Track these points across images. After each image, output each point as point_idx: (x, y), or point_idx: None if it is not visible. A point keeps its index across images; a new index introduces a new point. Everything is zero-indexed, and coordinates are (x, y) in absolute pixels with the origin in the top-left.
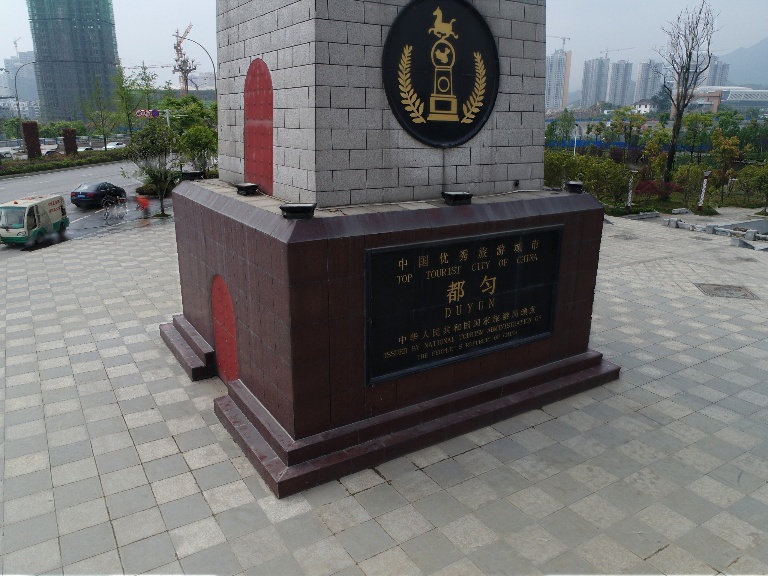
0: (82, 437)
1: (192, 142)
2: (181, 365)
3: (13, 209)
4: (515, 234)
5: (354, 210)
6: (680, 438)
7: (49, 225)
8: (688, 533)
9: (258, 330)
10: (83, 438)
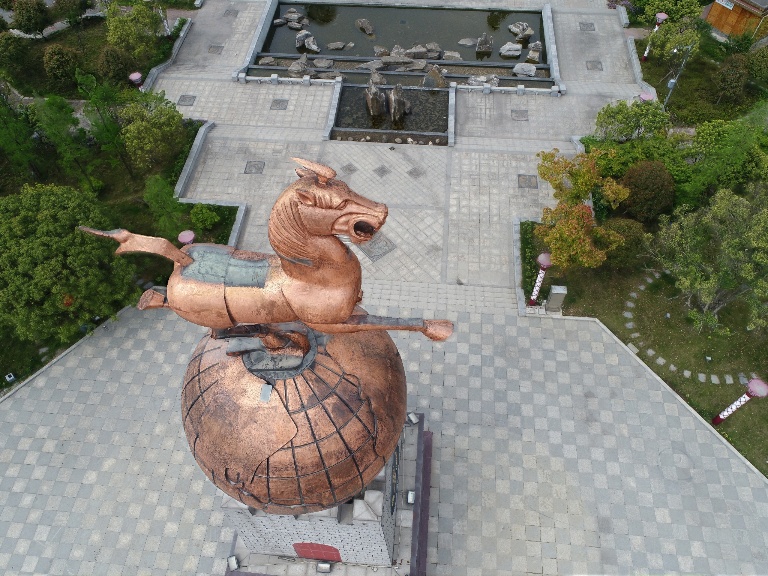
0: None
1: None
2: None
3: None
4: None
5: (403, 553)
6: (477, 463)
7: None
8: (511, 516)
9: None
10: None
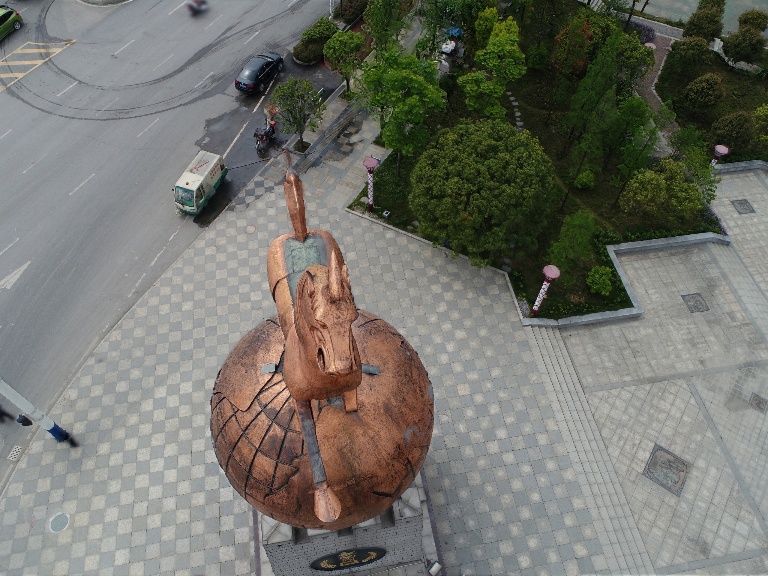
0: (202, 562)
1: (336, 57)
2: None
3: (186, 190)
4: None
5: None
6: None
7: (212, 191)
8: None
9: None
10: (203, 563)
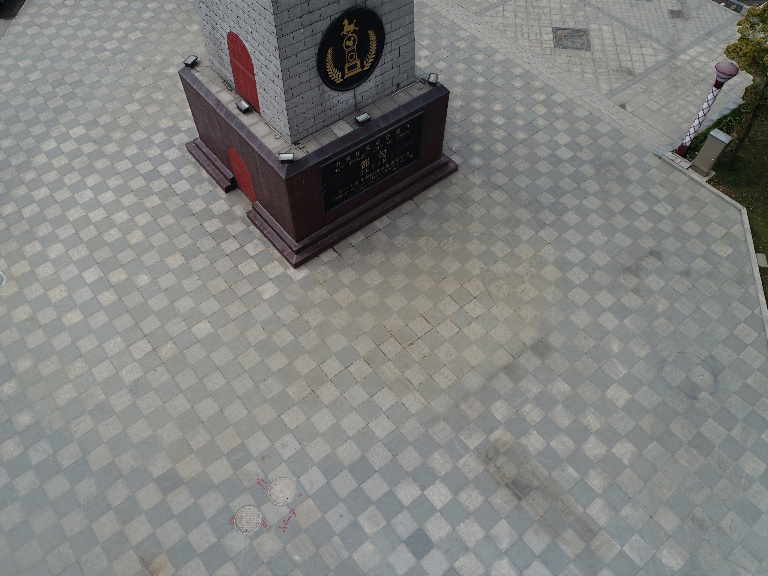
0: (190, 241)
1: None
2: (213, 179)
3: None
4: (395, 128)
5: (311, 145)
6: (473, 215)
7: None
8: (457, 270)
9: (269, 193)
10: (191, 242)
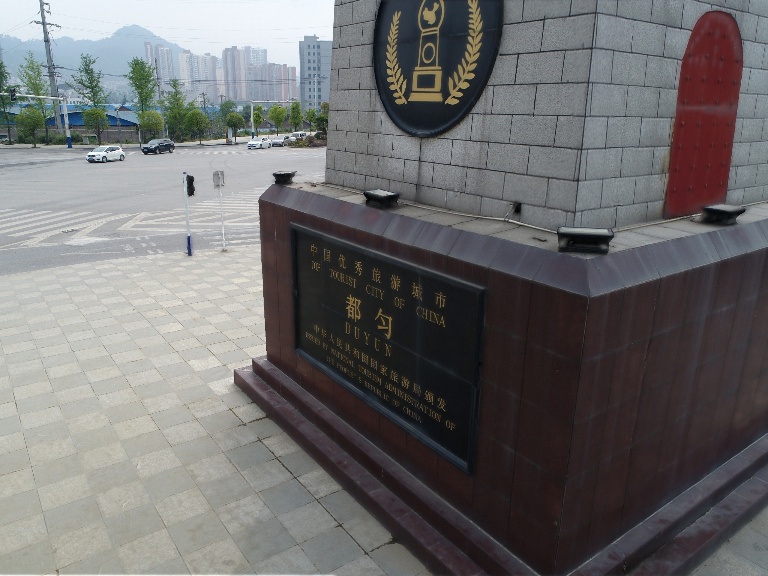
0: None
1: None
2: None
3: None
4: (408, 268)
5: (319, 188)
6: None
7: None
8: None
9: None
10: None
